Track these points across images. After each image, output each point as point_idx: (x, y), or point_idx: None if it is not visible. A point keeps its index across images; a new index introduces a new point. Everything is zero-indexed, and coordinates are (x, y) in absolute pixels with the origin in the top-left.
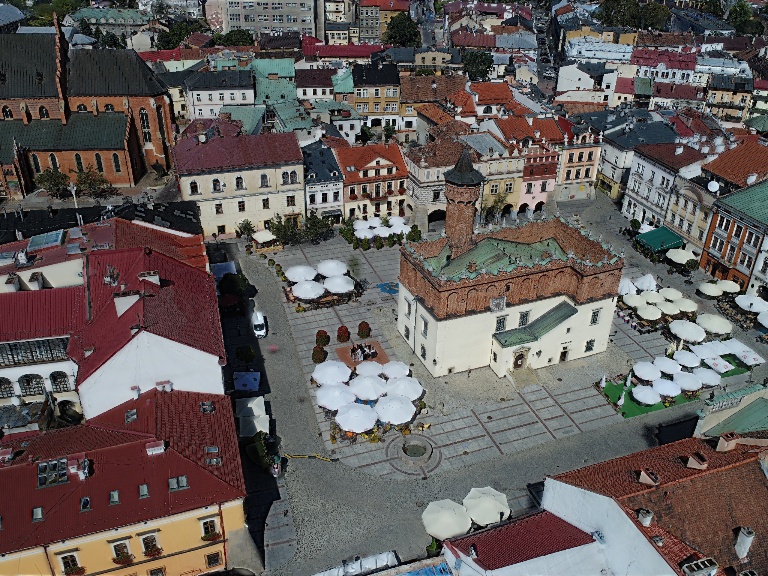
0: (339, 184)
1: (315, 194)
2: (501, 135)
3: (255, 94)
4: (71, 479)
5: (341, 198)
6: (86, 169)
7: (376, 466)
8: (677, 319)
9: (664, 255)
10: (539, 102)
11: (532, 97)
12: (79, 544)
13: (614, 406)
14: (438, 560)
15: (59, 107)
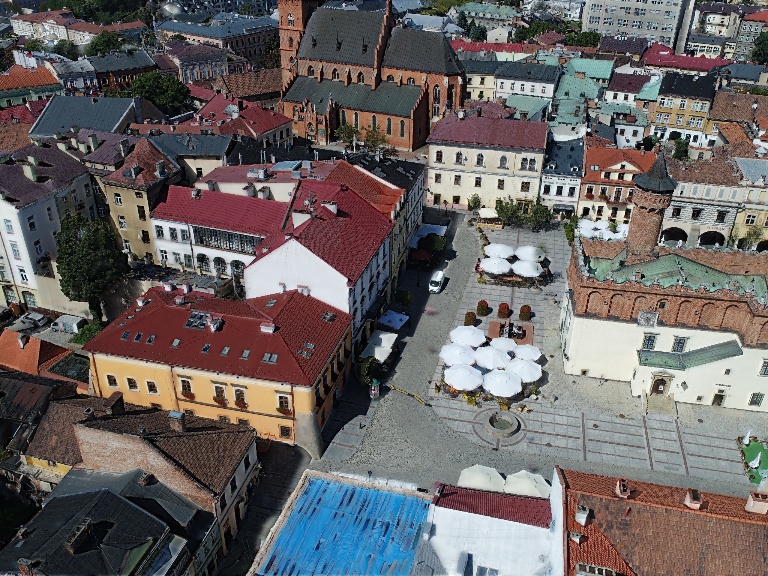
0: (577, 180)
1: (550, 185)
2: None
3: (556, 89)
4: (206, 329)
5: (576, 194)
6: (378, 130)
7: (459, 423)
8: None
9: None
10: None
11: None
12: (193, 374)
13: (745, 466)
14: (429, 496)
15: (372, 75)
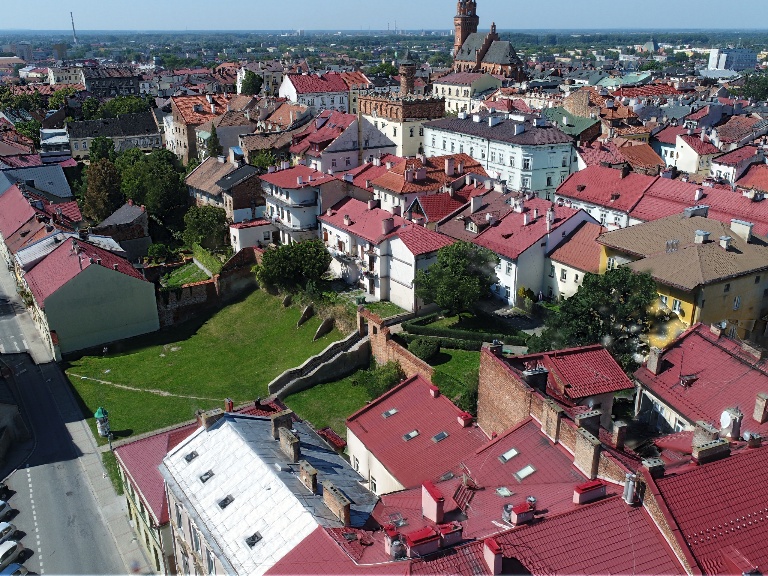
0: None
1: (474, 106)
2: None
3: None
4: None
5: None
6: None
7: None
8: None
9: None
10: None
11: (687, 93)
12: None
13: None
14: None
15: None
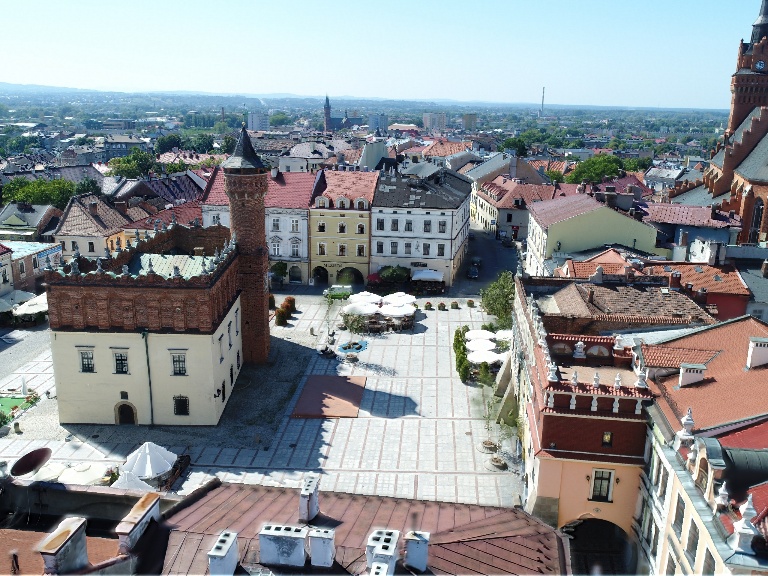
0: None
1: None
2: None
3: None
4: None
5: None
6: None
7: None
8: None
9: None
10: None
11: None
12: None
13: None
14: None
15: None
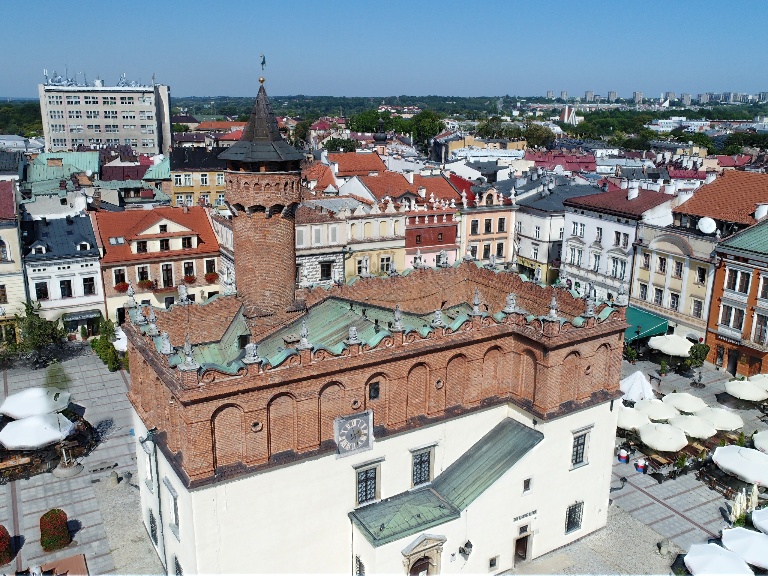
0: (92, 264)
1: (46, 282)
2: (368, 194)
3: None
4: None
5: (98, 289)
6: None
7: None
8: (714, 446)
9: (643, 348)
10: (421, 160)
11: None
12: None
13: None
14: None
15: None
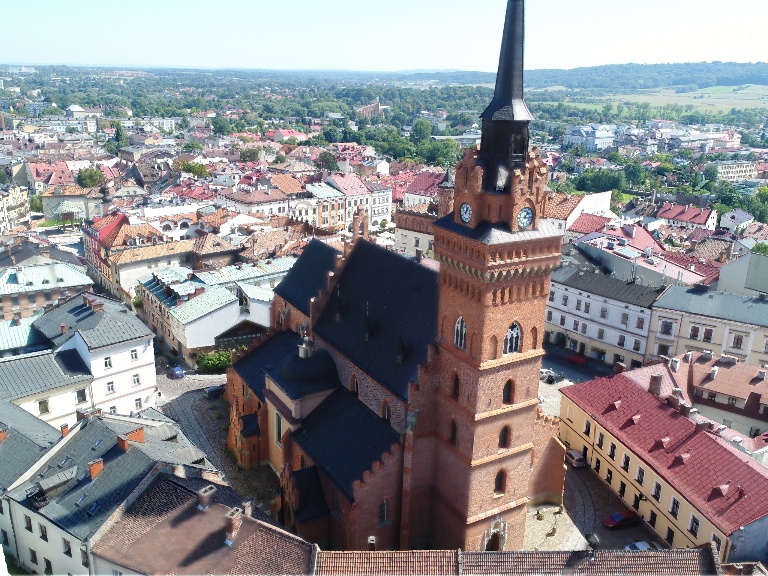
0: None
1: None
2: None
3: None
4: None
5: None
6: None
7: None
8: None
9: None
10: (194, 202)
11: None
12: None
13: None
14: None
15: None
